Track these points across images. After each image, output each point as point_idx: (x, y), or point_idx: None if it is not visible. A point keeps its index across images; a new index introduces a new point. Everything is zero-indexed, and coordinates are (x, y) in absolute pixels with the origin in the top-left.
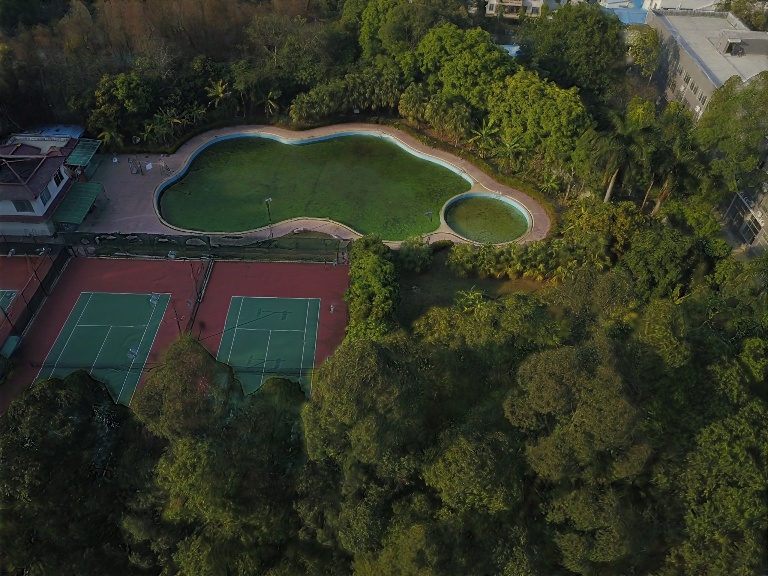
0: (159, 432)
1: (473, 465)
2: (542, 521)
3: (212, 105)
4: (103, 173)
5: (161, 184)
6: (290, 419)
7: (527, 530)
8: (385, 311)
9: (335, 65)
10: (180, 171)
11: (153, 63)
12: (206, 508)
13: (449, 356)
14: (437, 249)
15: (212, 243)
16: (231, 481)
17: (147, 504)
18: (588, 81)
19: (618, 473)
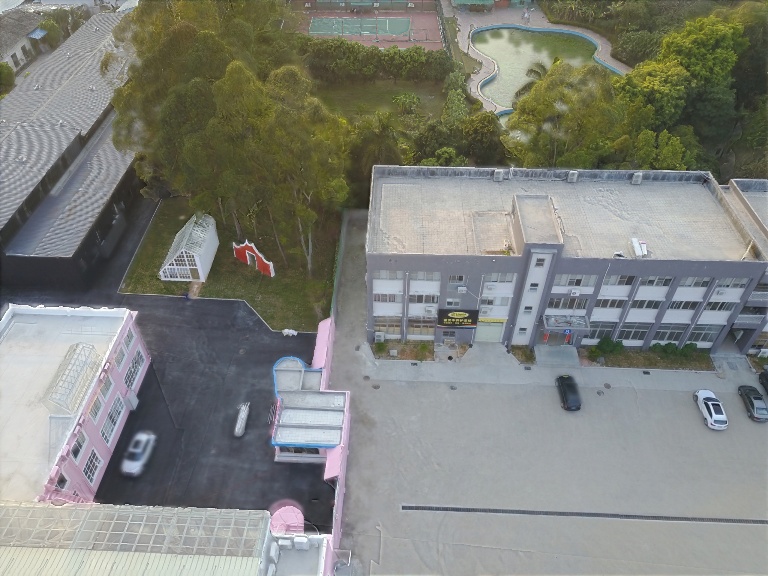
0: None
1: None
2: None
3: None
4: (519, 10)
5: (515, 24)
6: None
7: None
8: (373, 51)
9: None
10: (532, 27)
11: None
12: None
13: None
14: (473, 102)
15: (459, 40)
16: None
17: None
18: (759, 137)
19: None
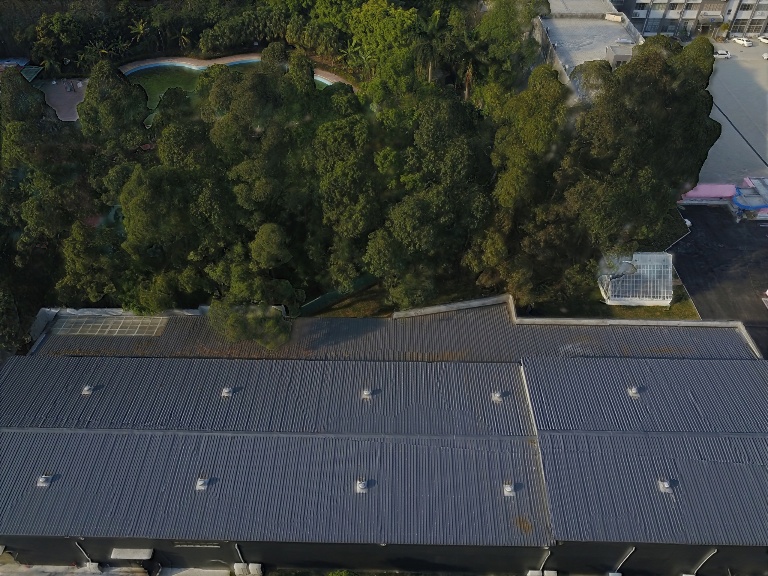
0: (4, 130)
1: (172, 134)
2: (228, 181)
3: (135, 40)
4: None
5: None
6: (95, 144)
7: (215, 181)
8: None
9: (237, 7)
10: None
11: (84, 6)
12: (22, 154)
13: (174, 90)
14: None
15: None
16: (39, 146)
17: (4, 183)
18: None
19: (264, 146)
